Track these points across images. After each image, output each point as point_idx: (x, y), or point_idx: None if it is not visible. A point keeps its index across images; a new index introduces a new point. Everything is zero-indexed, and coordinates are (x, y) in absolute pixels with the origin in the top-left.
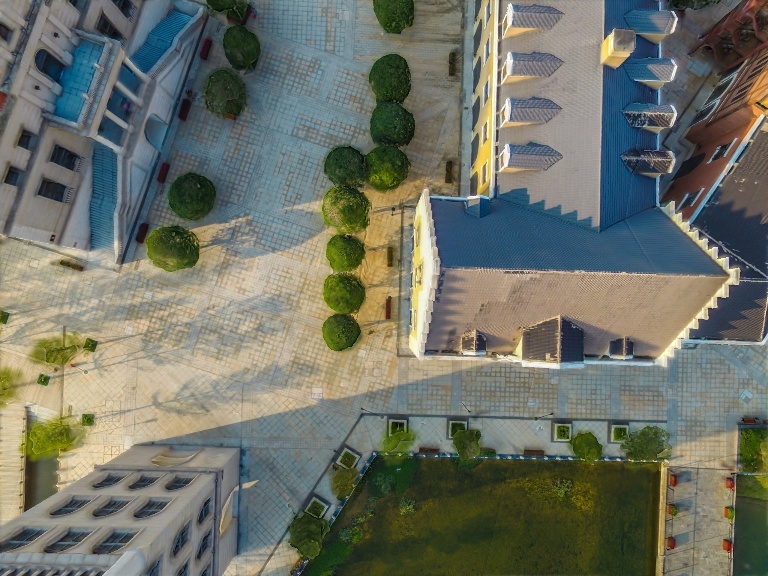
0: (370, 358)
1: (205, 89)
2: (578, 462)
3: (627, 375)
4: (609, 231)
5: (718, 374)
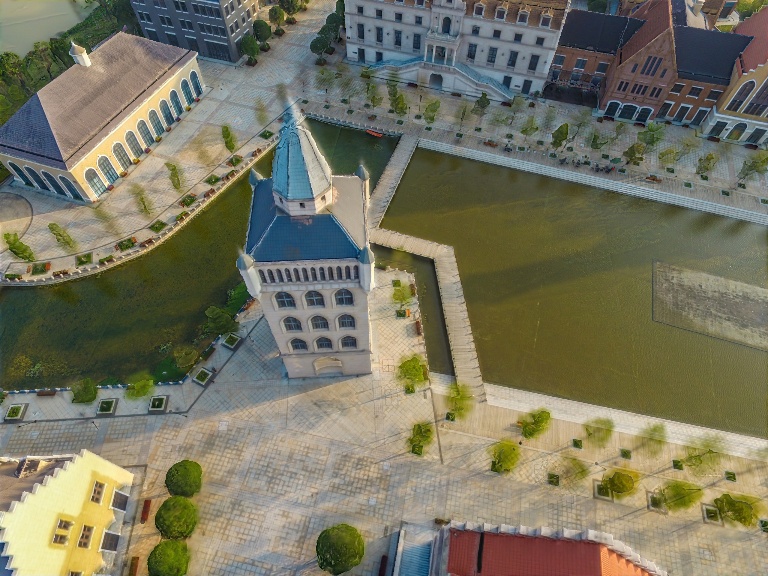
0: (173, 461)
1: None
2: None
3: None
4: None
5: None
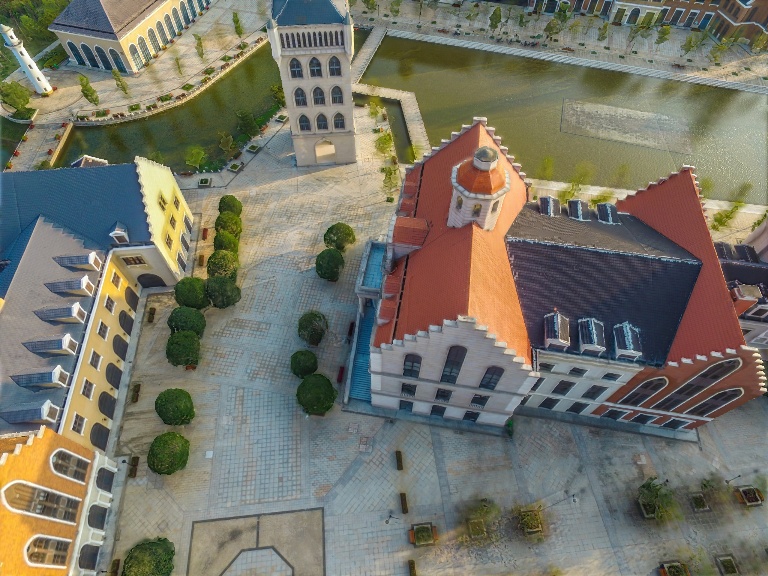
0: None
1: (339, 347)
2: None
3: None
4: (34, 216)
5: None
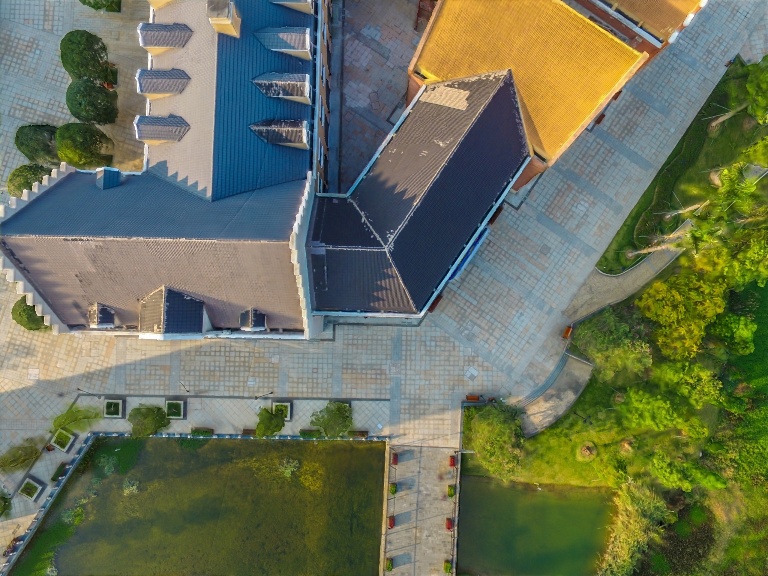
0: (87, 338)
1: None
2: (306, 442)
3: (349, 353)
4: (223, 201)
5: (443, 352)
